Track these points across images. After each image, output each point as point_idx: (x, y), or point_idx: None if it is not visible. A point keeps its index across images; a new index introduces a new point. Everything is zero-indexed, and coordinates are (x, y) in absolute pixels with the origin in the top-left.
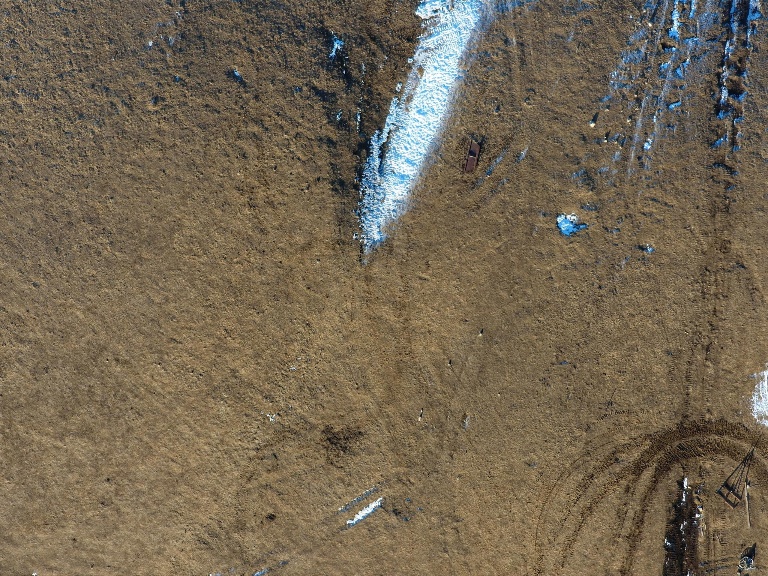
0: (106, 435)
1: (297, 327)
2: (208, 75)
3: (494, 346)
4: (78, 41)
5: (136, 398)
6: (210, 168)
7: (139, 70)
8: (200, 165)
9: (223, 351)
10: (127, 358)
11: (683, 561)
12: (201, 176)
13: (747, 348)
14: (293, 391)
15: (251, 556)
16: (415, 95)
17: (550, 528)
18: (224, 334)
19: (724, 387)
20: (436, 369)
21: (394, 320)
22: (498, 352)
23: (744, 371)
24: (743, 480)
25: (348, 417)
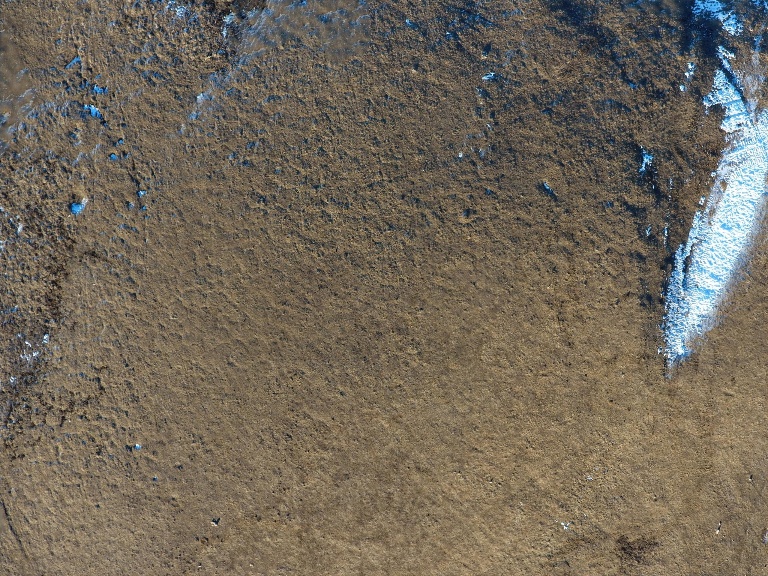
0: (401, 540)
1: (597, 438)
2: (519, 188)
3: None
4: (388, 151)
5: (434, 505)
6: (520, 281)
7: (450, 182)
8: (510, 278)
9: (523, 461)
10: (428, 466)
11: None
12: (511, 289)
13: None
14: (589, 501)
15: None
16: (718, 209)
17: None
18: (526, 444)
19: None
20: (736, 483)
21: (697, 434)
22: None
23: None
24: None
25: (644, 528)
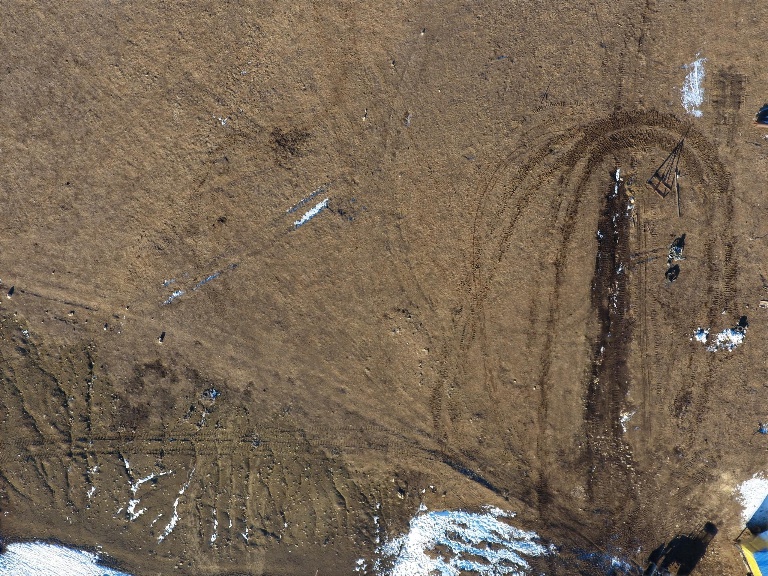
0: (66, 137)
1: (248, 30)
2: None
3: (435, 44)
4: None
5: (94, 100)
6: None
7: None
8: None
9: (177, 53)
10: (85, 59)
11: (615, 254)
12: None
13: (678, 39)
14: (244, 95)
15: (204, 260)
16: None
17: (487, 221)
18: (178, 36)
19: (655, 78)
20: (380, 70)
21: (340, 21)
22: (439, 50)
23: (675, 62)
24: (673, 170)
25: (296, 119)
